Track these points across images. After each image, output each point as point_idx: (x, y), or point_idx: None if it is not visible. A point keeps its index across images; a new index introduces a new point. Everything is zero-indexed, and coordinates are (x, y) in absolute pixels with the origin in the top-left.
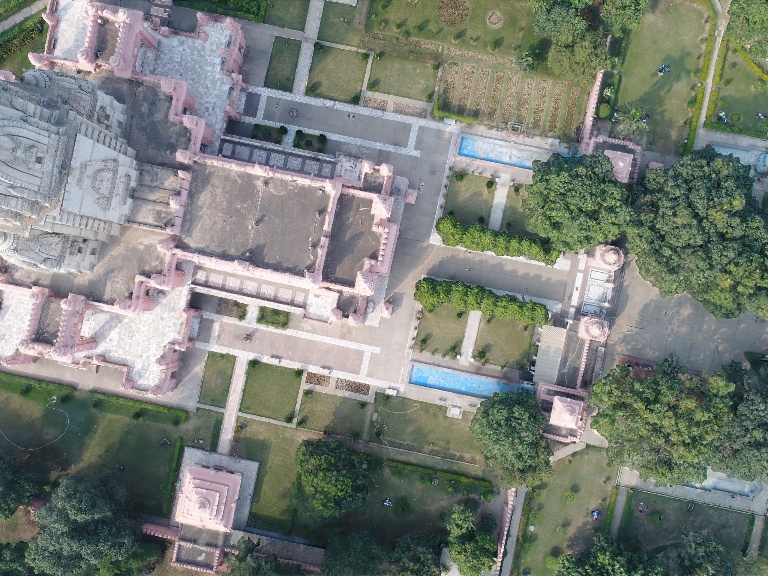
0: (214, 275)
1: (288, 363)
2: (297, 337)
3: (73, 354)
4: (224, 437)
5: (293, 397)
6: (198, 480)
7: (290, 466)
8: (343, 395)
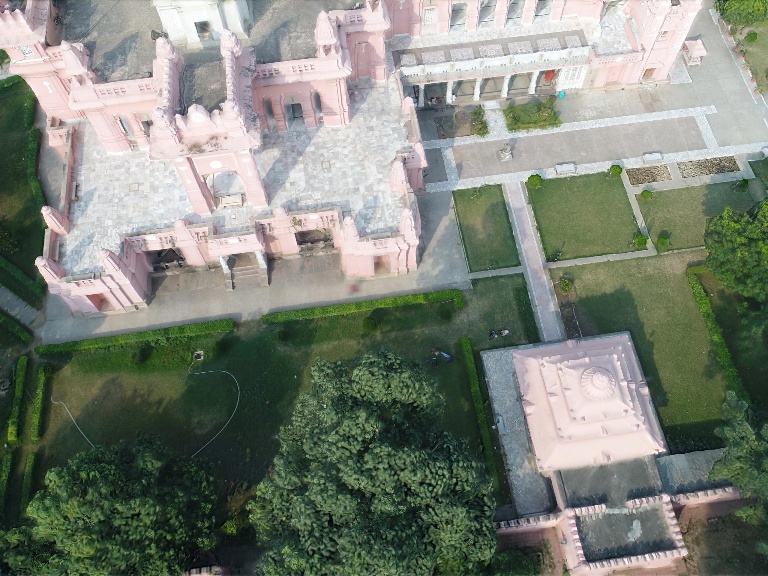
0: (428, 54)
1: (588, 168)
2: (581, 130)
3: (259, 131)
4: (542, 312)
5: (624, 212)
6: (556, 356)
7: (685, 319)
8: (701, 183)
